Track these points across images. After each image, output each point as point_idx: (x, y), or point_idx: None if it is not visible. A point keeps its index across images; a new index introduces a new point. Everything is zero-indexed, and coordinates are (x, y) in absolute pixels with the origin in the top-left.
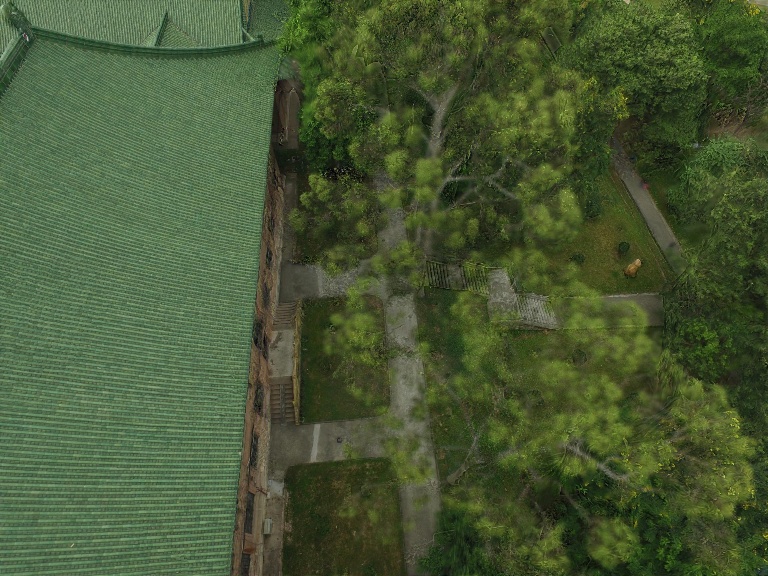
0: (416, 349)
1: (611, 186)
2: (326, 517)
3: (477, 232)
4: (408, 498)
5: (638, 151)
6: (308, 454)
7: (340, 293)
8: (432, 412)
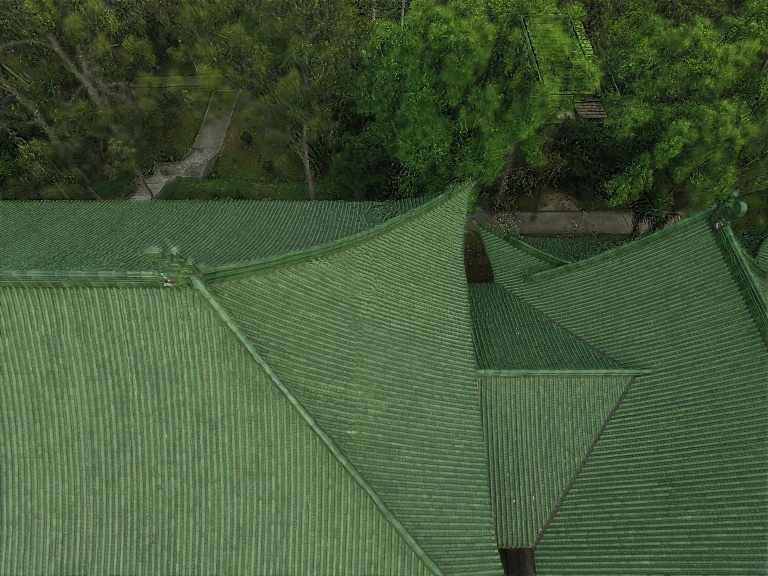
0: None
1: None
2: None
3: None
4: None
5: None
6: None
7: None
8: None
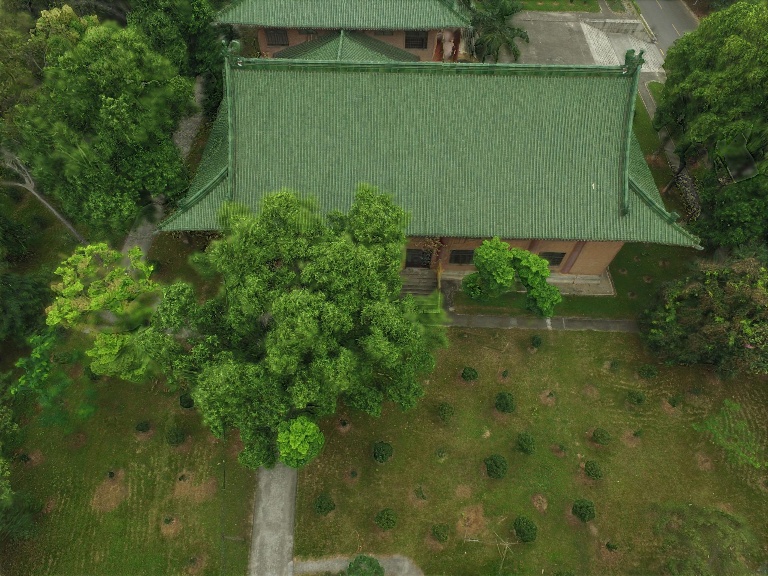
0: None
1: None
2: None
3: None
4: None
5: None
6: None
7: None
8: None
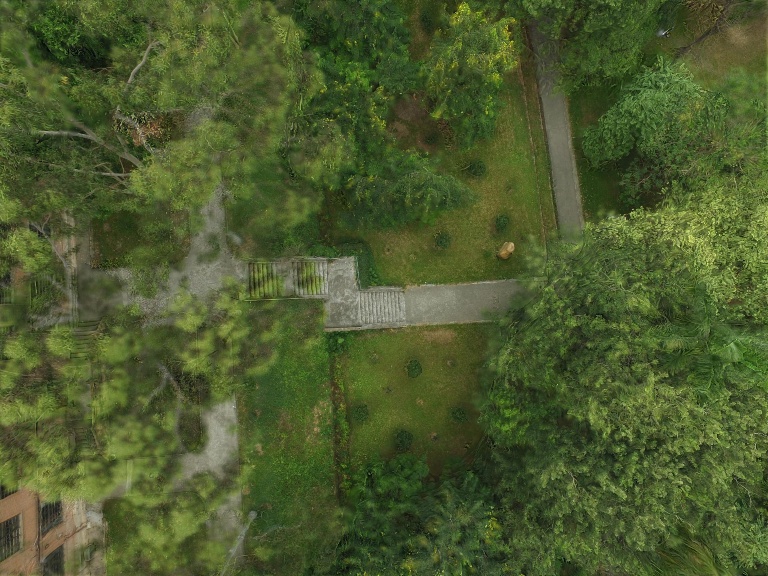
0: (229, 380)
1: (518, 114)
2: (141, 544)
3: (332, 194)
4: (215, 528)
5: (554, 73)
6: (123, 488)
7: (147, 309)
8: (241, 449)
